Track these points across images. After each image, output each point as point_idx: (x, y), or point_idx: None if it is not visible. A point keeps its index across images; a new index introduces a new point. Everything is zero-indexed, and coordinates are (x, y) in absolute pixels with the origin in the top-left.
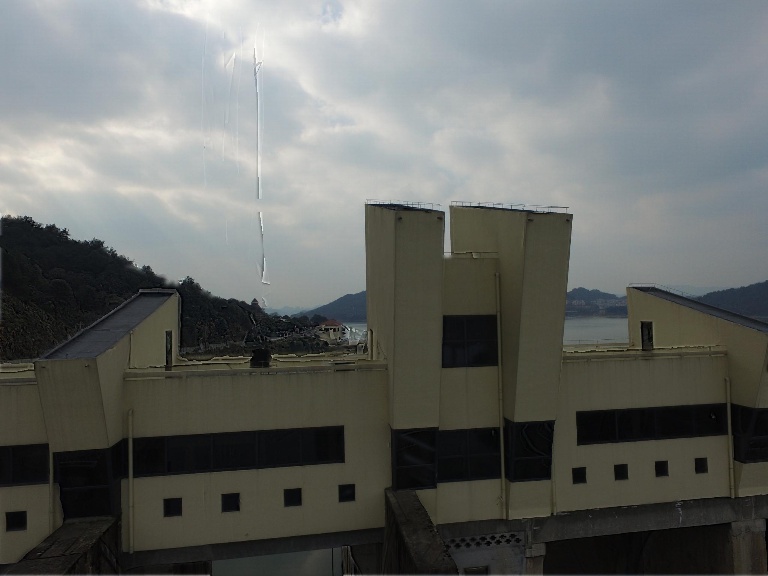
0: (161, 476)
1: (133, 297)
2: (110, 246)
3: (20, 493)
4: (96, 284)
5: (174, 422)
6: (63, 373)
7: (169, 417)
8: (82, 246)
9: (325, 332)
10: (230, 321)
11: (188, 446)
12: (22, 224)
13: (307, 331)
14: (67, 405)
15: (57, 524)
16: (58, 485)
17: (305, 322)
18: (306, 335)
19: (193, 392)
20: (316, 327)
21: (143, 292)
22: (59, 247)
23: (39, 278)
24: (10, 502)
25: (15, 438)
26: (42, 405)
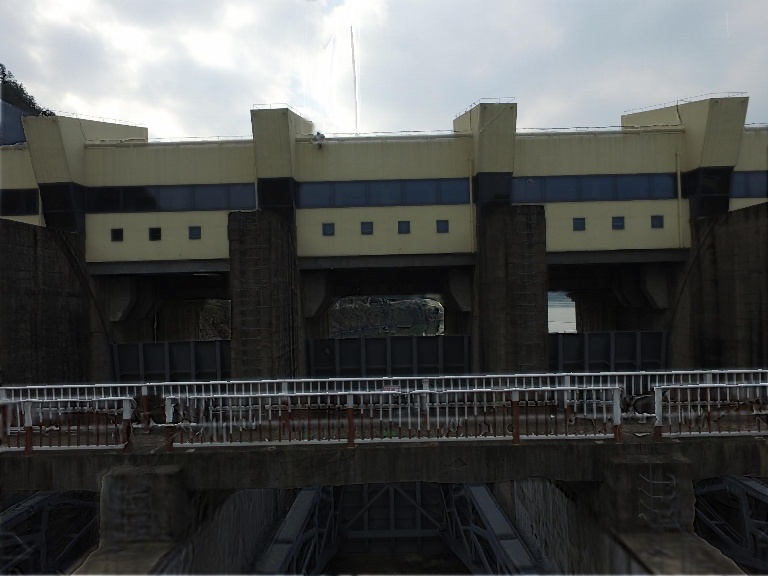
0: (745, 198)
1: None
2: None
3: (659, 204)
4: None
5: (752, 162)
6: (726, 107)
7: (748, 158)
8: None
9: None
10: None
11: (756, 181)
12: None
13: None
14: (721, 131)
15: (684, 224)
16: (682, 199)
17: None
18: (417, 301)
19: (764, 141)
20: None
21: None
22: None
23: None
24: (653, 209)
25: (653, 168)
26: (706, 131)
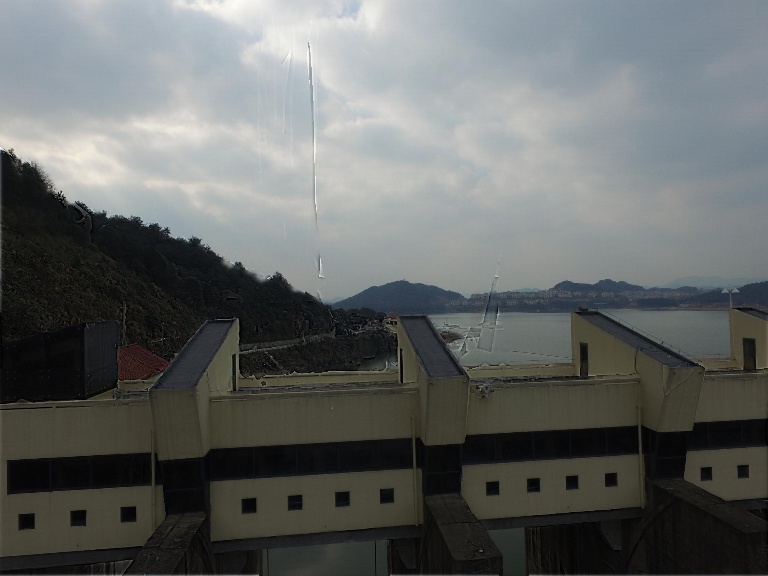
0: None
1: (743, 312)
2: (206, 243)
3: None
4: (206, 280)
5: None
6: None
7: None
8: (184, 244)
9: (395, 325)
10: (316, 315)
11: None
12: (131, 223)
13: (379, 324)
14: None
15: None
16: None
17: (370, 315)
18: (379, 328)
19: None
20: (383, 320)
21: (734, 307)
22: (165, 245)
23: (177, 276)
24: None
25: None
26: None
